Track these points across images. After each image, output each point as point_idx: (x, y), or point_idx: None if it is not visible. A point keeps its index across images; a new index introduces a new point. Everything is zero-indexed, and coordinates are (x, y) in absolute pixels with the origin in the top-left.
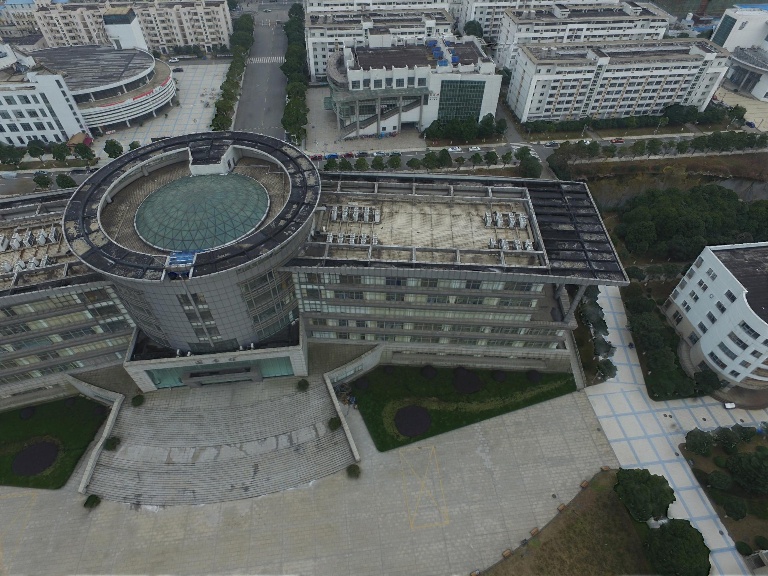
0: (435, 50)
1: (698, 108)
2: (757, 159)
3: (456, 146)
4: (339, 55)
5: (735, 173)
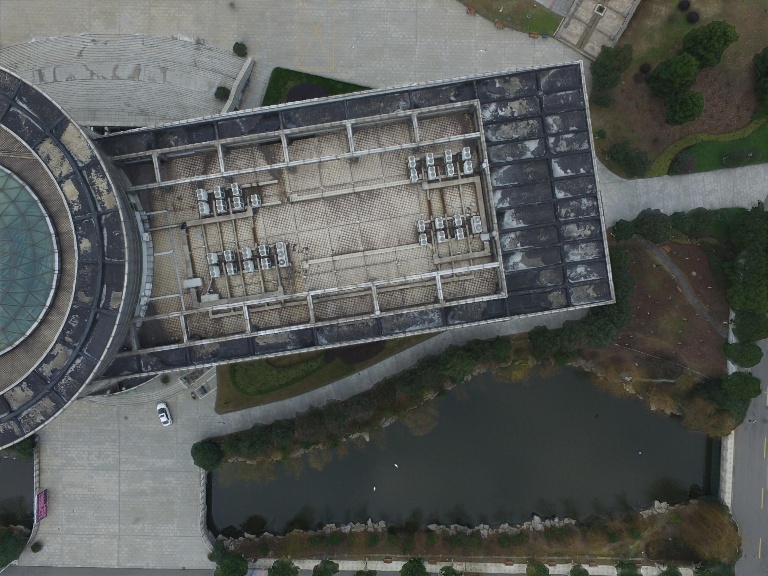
0: None
1: None
2: None
3: None
4: None
5: None
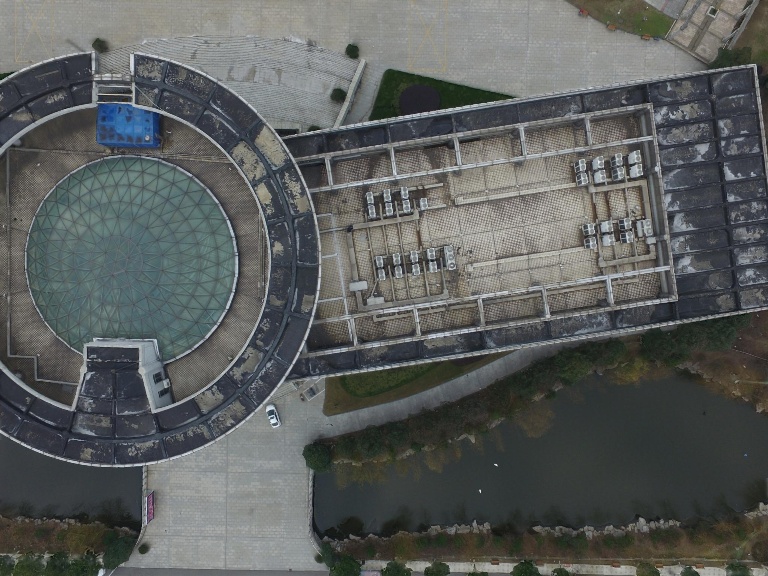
0: None
1: None
2: None
3: None
4: None
5: None
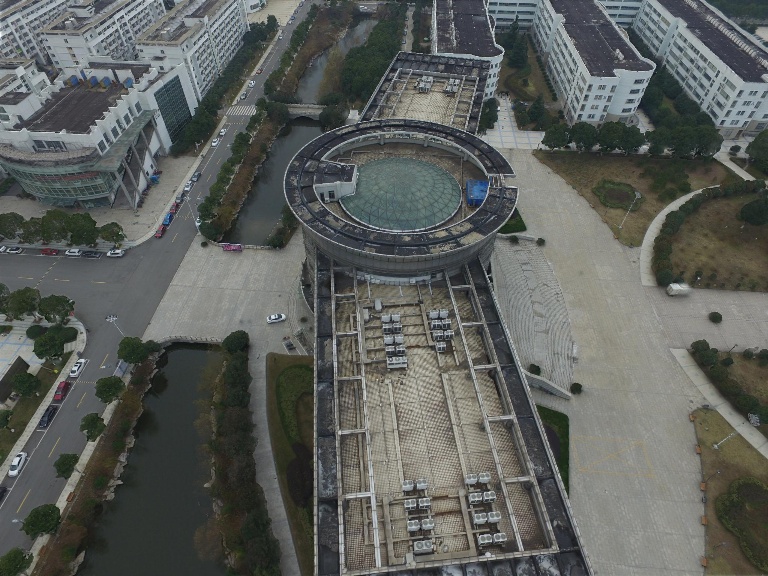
0: (93, 81)
1: (246, 31)
2: (315, 36)
3: (210, 140)
4: (8, 148)
5: (321, 49)
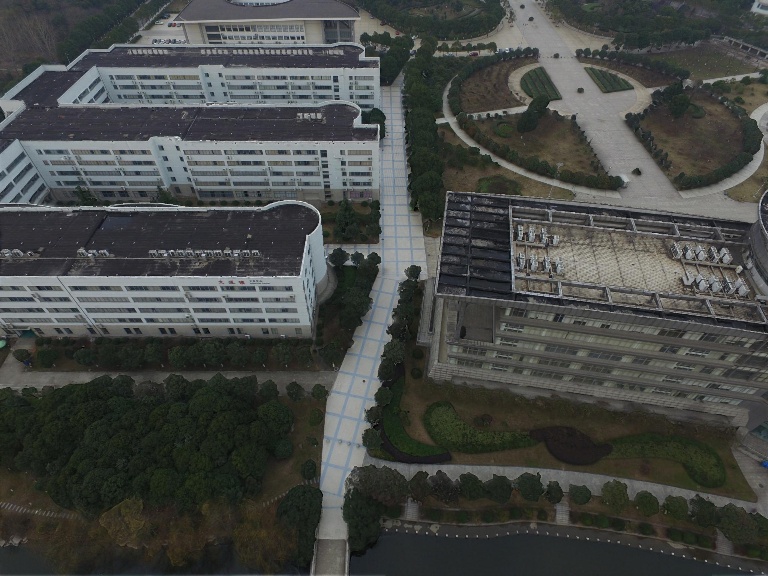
0: None
1: None
2: None
3: None
4: None
5: None
